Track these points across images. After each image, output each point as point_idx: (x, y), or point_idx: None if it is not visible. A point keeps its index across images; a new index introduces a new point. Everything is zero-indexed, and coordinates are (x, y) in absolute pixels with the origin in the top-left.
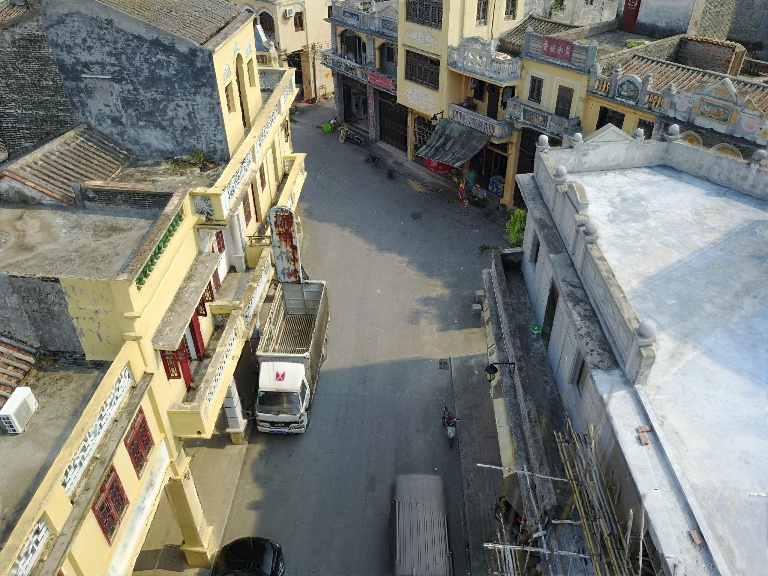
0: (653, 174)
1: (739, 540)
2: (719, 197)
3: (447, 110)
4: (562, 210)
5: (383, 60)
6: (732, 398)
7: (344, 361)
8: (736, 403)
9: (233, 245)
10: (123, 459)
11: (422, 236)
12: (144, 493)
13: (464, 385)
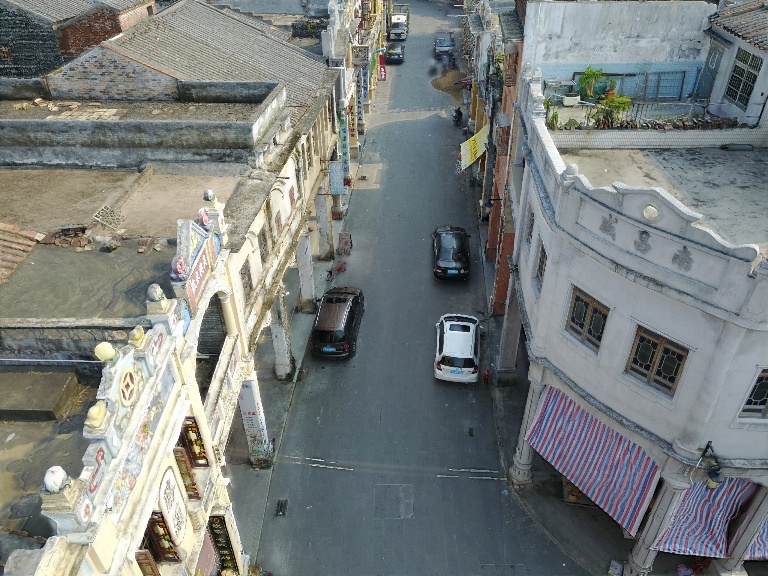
0: None
1: None
2: None
3: None
4: None
5: None
6: None
7: (415, 33)
8: None
9: None
10: None
11: (443, 14)
12: None
13: None
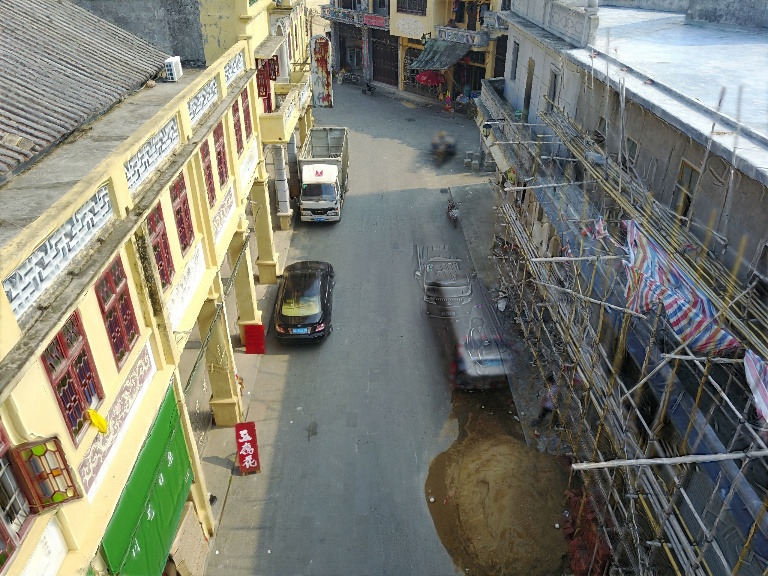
0: None
1: None
2: (647, 12)
3: (434, 31)
4: (534, 5)
5: (375, 7)
6: (650, 47)
7: (363, 191)
8: (652, 48)
9: (281, 69)
10: None
11: (417, 130)
12: None
13: (462, 199)
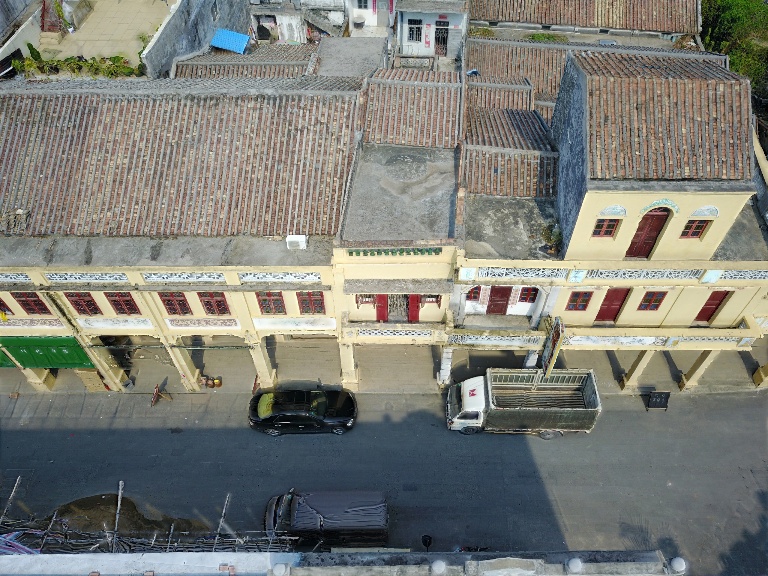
0: None
1: None
2: None
3: None
4: None
5: None
6: None
7: (545, 456)
8: None
9: None
10: (292, 299)
11: None
12: (303, 321)
13: None
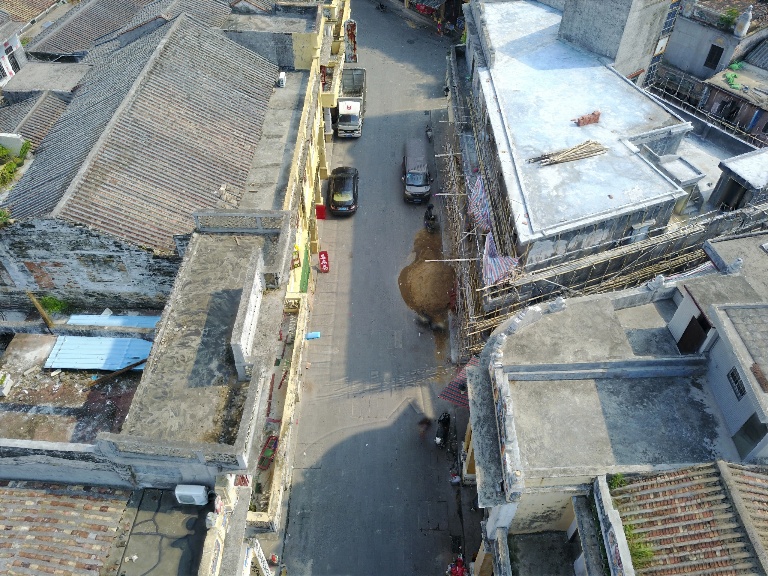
0: (526, 3)
1: (507, 97)
2: (551, 13)
3: None
4: (477, 16)
5: None
6: (520, 72)
7: (375, 112)
8: (521, 73)
9: None
10: None
11: (415, 53)
12: None
13: (437, 120)
